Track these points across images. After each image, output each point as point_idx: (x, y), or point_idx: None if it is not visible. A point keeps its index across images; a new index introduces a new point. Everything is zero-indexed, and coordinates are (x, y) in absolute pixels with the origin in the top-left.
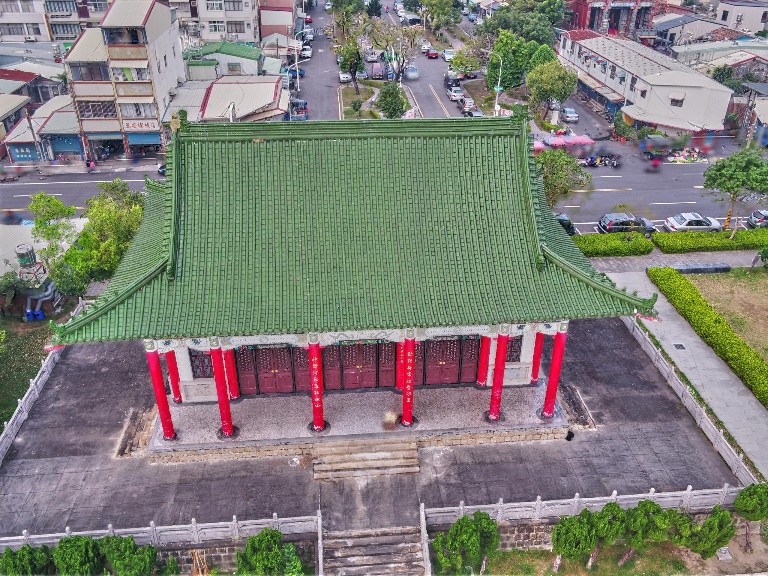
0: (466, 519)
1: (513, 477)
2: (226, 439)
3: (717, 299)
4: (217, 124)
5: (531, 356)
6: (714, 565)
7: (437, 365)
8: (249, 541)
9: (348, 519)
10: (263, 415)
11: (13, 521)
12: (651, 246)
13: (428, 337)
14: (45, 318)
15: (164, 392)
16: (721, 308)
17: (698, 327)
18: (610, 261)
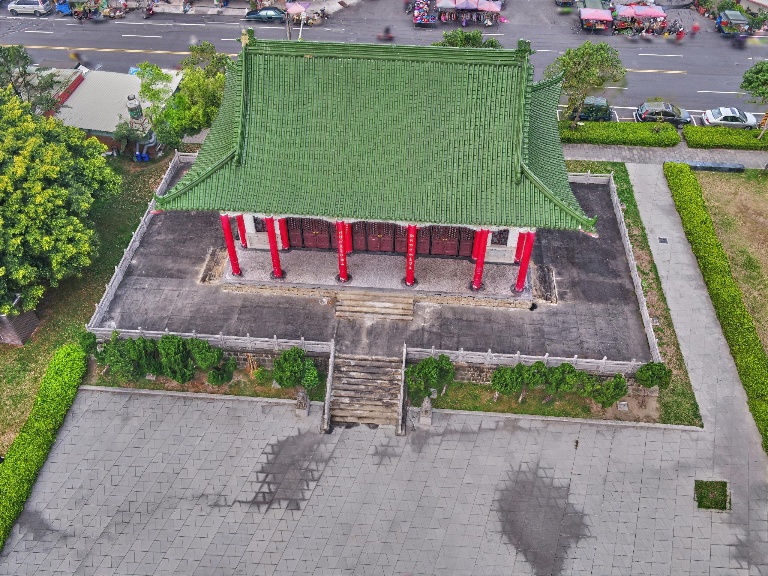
0: (431, 359)
1: (480, 333)
2: (276, 280)
3: (718, 199)
4: (277, 41)
5: (516, 242)
6: (612, 413)
7: (441, 241)
8: (282, 354)
9: (354, 347)
10: (305, 264)
11: (132, 319)
12: (677, 140)
13: (426, 225)
14: (150, 160)
15: (233, 243)
16: (718, 208)
17: (686, 225)
18: (634, 151)
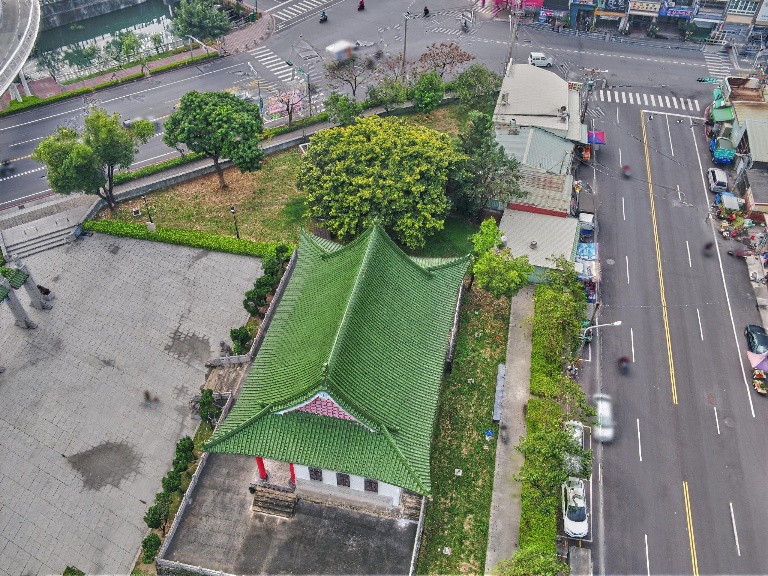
0: (209, 399)
1: None
2: None
3: None
4: None
5: None
6: None
7: None
8: None
9: None
10: None
11: None
12: None
13: None
14: None
15: None
16: None
17: None
18: None
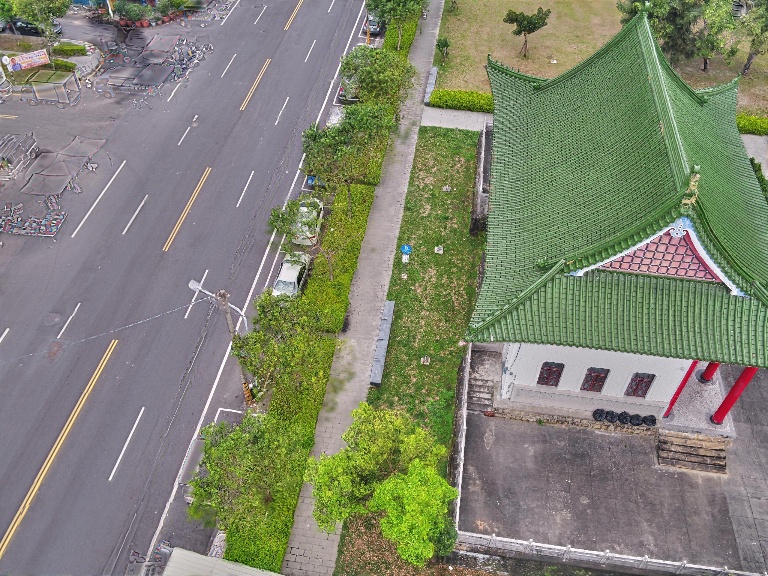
0: None
1: None
2: (714, 379)
3: None
4: None
5: None
6: None
7: None
8: None
9: None
10: None
11: None
12: None
13: None
14: None
15: None
16: None
17: None
18: None
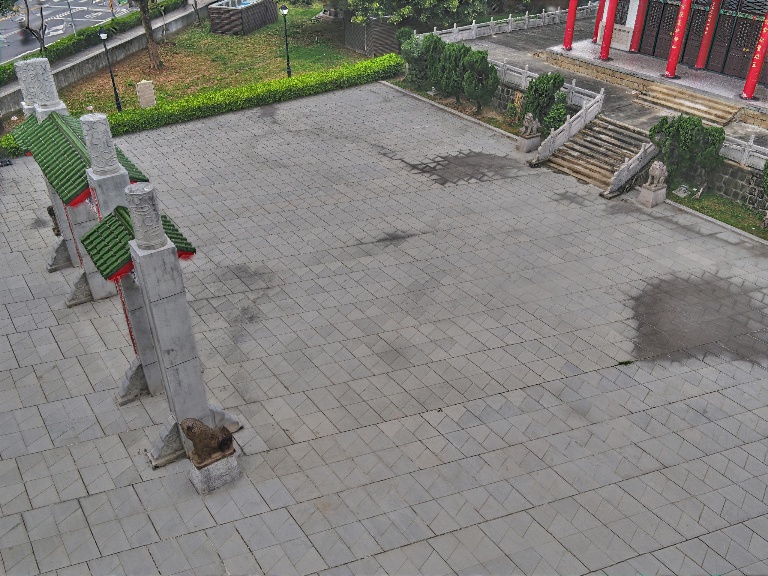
0: None
1: None
2: (598, 60)
3: None
4: None
5: None
6: None
7: None
8: None
9: (625, 118)
10: (639, 61)
11: None
12: None
13: None
14: None
15: (576, 1)
16: None
17: None
18: None
